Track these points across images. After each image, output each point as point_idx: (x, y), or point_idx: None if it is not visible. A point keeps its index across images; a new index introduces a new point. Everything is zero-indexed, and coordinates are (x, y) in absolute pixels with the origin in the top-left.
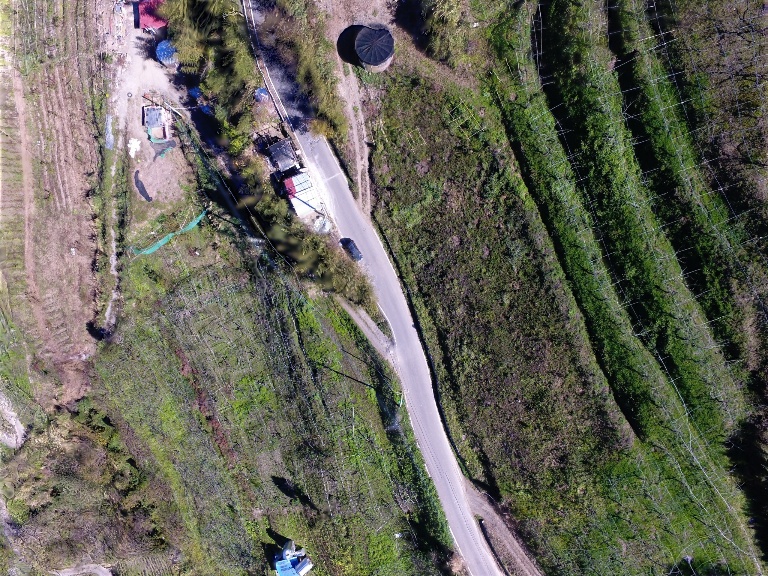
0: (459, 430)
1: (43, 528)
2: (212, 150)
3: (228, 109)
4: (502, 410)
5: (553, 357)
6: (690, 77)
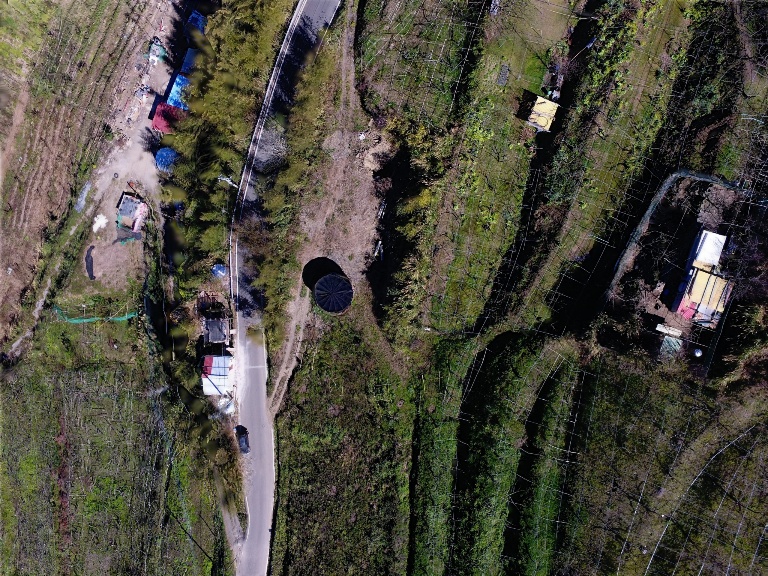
0: None
1: None
2: (168, 266)
3: (189, 256)
4: None
5: None
6: (574, 504)
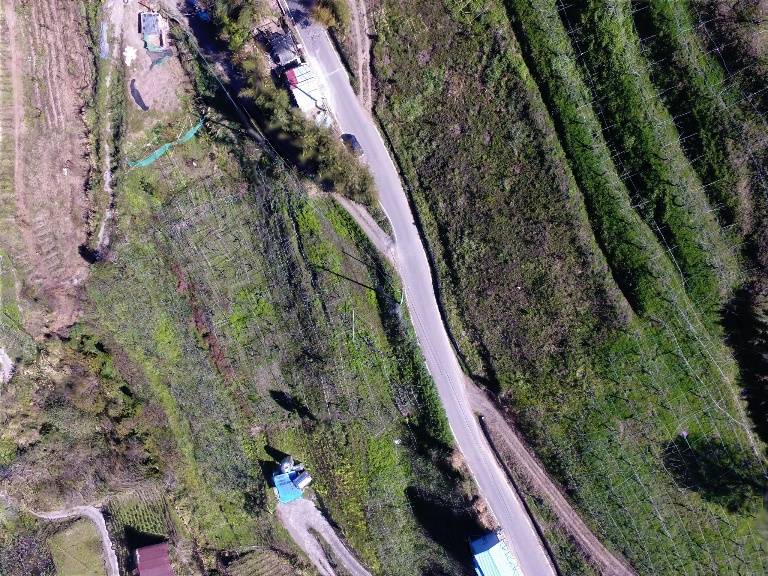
0: (459, 326)
1: (31, 466)
2: (210, 56)
3: (228, 5)
4: (502, 299)
5: (553, 239)
6: None
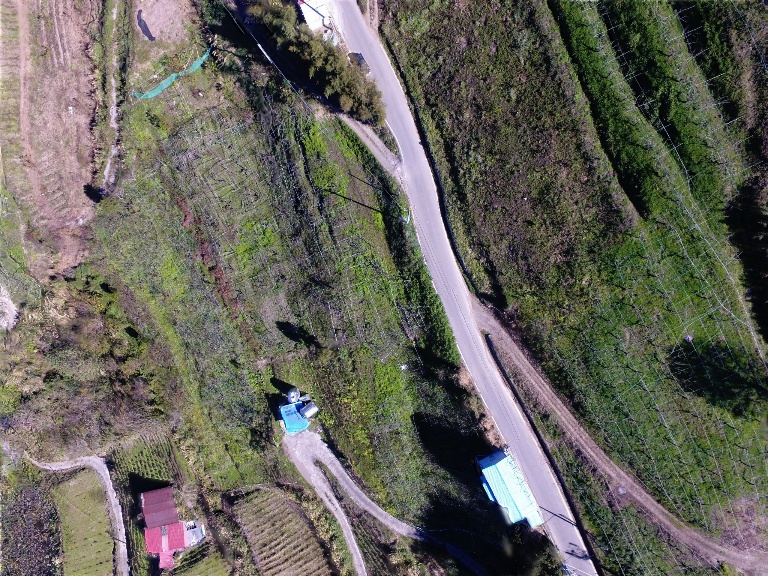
0: (466, 243)
1: (35, 415)
2: None
3: None
4: (509, 212)
5: (559, 146)
6: None
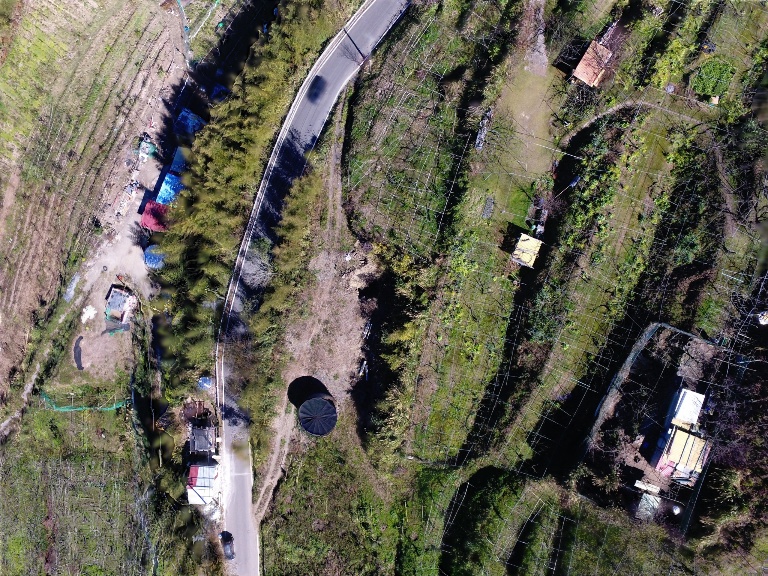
0: None
1: None
2: (156, 360)
3: (176, 361)
4: None
5: None
6: None
